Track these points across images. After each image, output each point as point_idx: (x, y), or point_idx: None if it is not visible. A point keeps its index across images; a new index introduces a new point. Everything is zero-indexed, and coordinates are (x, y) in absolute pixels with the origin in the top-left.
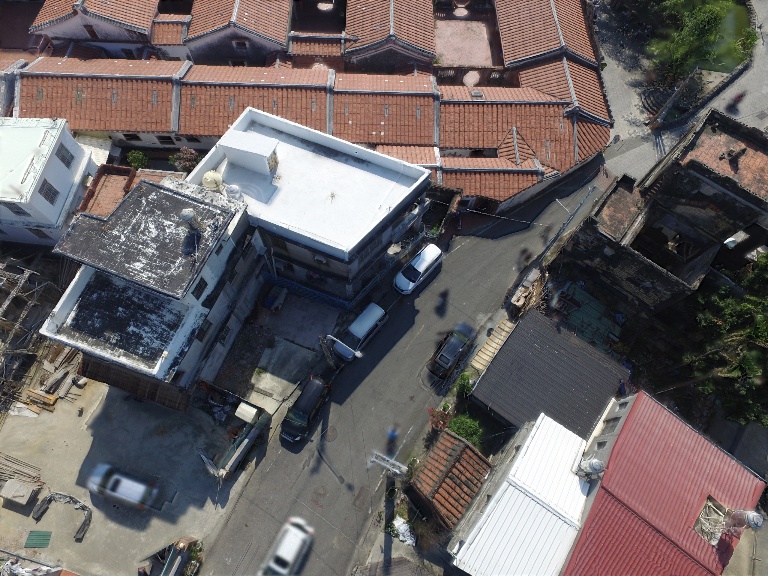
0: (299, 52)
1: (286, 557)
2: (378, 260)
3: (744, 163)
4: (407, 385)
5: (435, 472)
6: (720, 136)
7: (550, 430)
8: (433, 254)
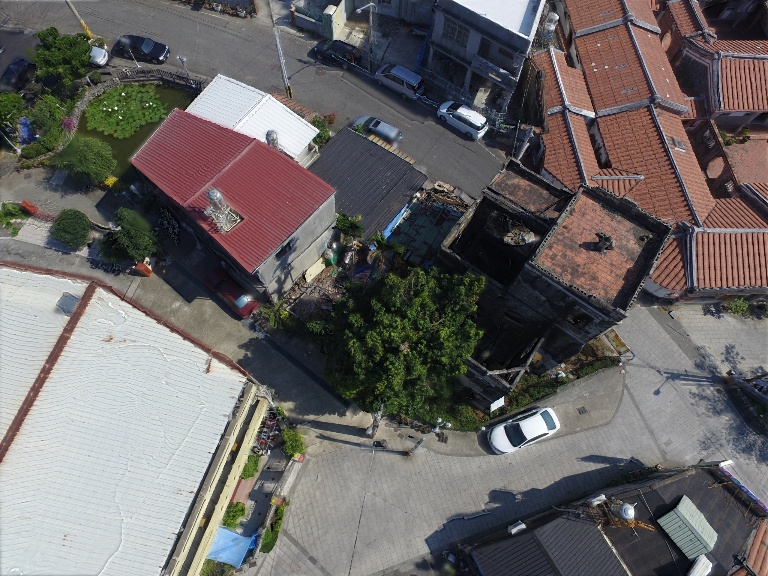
0: (673, 8)
1: (243, 53)
2: (456, 65)
3: (599, 259)
4: (358, 115)
5: (285, 102)
6: (636, 243)
7: (305, 133)
8: (475, 119)
